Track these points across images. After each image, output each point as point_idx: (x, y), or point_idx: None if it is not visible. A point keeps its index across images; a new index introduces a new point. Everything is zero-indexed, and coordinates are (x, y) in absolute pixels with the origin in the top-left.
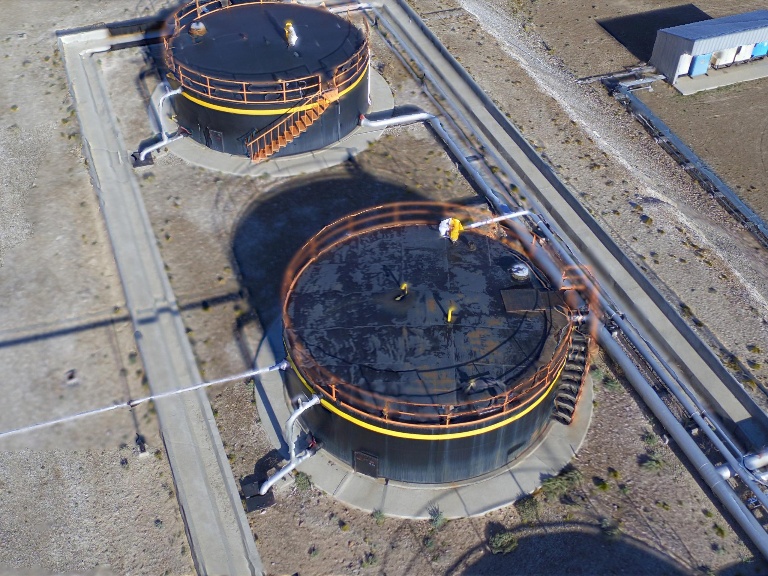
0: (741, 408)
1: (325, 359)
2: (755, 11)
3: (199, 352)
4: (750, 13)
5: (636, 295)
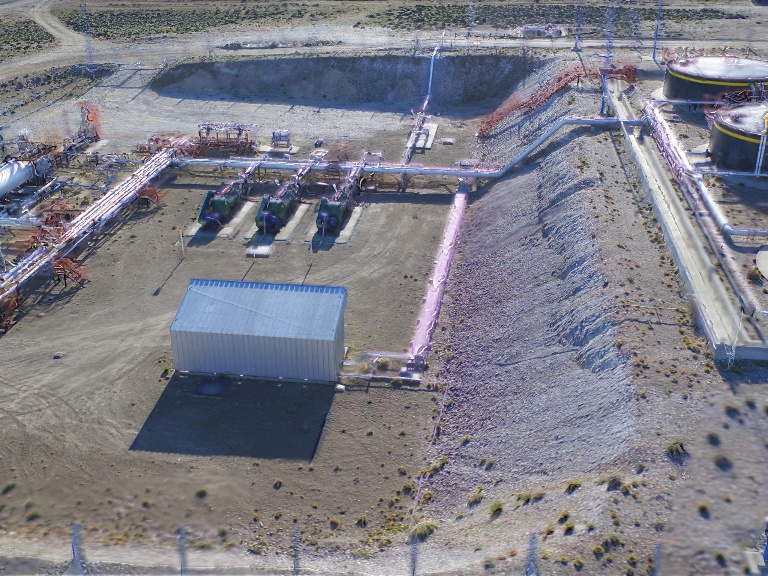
0: None
1: None
2: (185, 329)
3: None
4: (198, 326)
5: (643, 159)
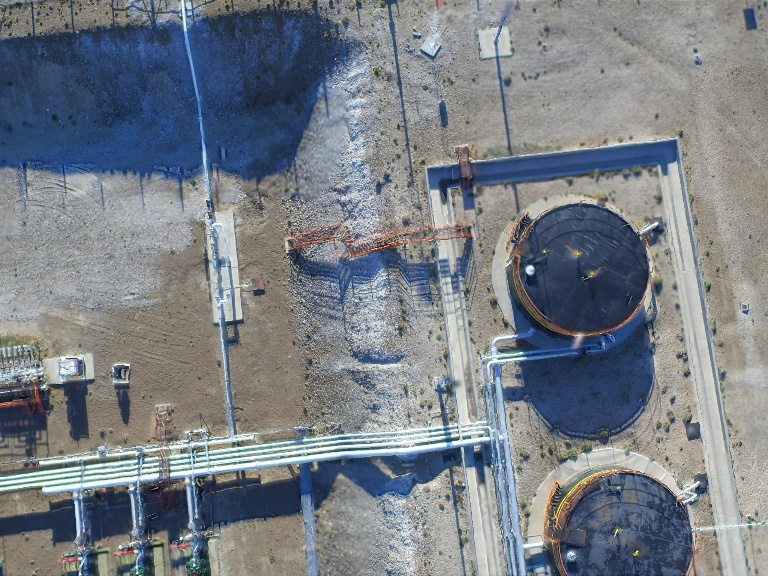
0: (468, 474)
1: (678, 523)
2: None
3: (720, 575)
4: None
5: (484, 560)
